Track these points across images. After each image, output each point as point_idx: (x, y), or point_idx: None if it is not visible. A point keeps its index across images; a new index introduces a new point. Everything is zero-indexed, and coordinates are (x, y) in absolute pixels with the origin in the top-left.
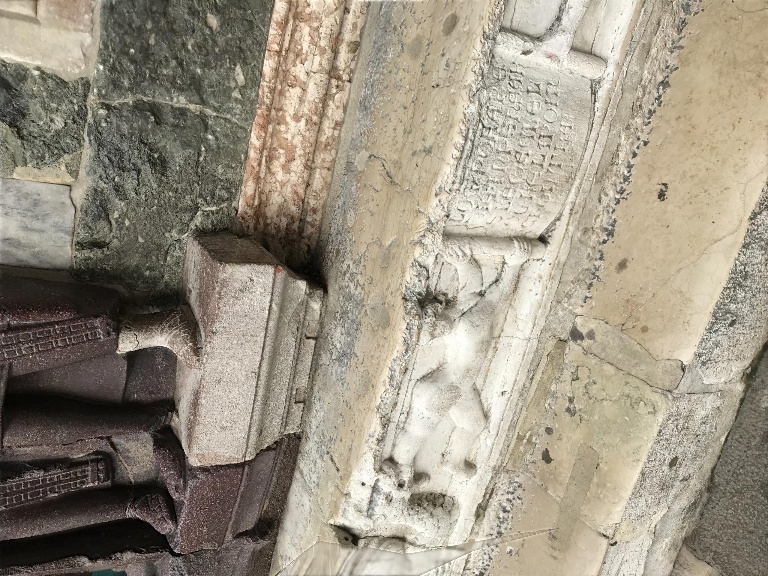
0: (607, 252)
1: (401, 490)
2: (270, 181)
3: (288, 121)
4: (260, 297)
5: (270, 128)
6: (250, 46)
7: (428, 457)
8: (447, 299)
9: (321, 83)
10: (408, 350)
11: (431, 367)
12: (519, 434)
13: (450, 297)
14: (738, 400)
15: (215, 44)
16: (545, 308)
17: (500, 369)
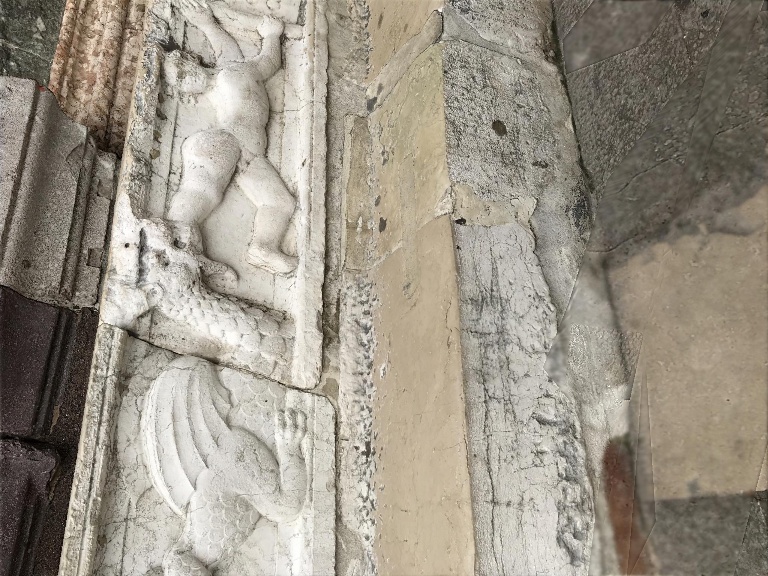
0: (370, 28)
1: (179, 250)
2: (75, 105)
3: (89, 60)
4: (19, 105)
5: (71, 61)
6: (50, 8)
7: (229, 246)
8: (204, 64)
9: (114, 28)
10: (150, 75)
11: (202, 129)
12: (348, 222)
13: (207, 62)
14: (559, 82)
15: (19, 4)
16: (320, 74)
17: (295, 144)
